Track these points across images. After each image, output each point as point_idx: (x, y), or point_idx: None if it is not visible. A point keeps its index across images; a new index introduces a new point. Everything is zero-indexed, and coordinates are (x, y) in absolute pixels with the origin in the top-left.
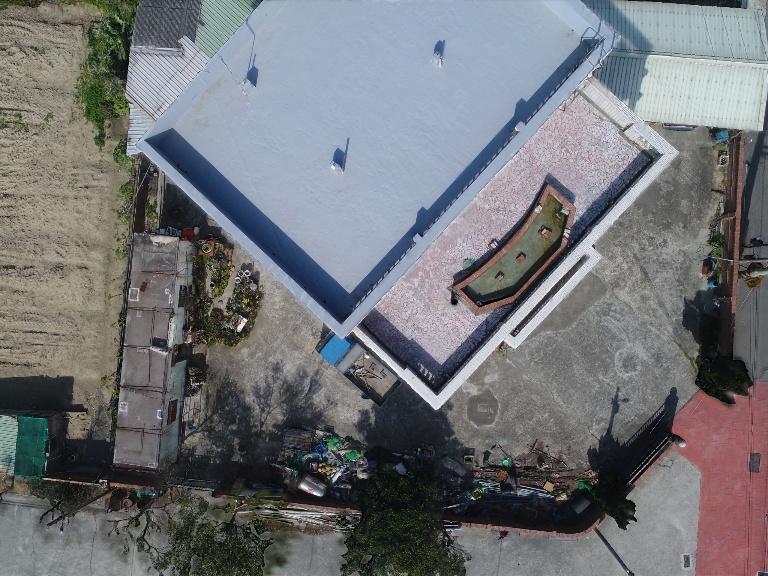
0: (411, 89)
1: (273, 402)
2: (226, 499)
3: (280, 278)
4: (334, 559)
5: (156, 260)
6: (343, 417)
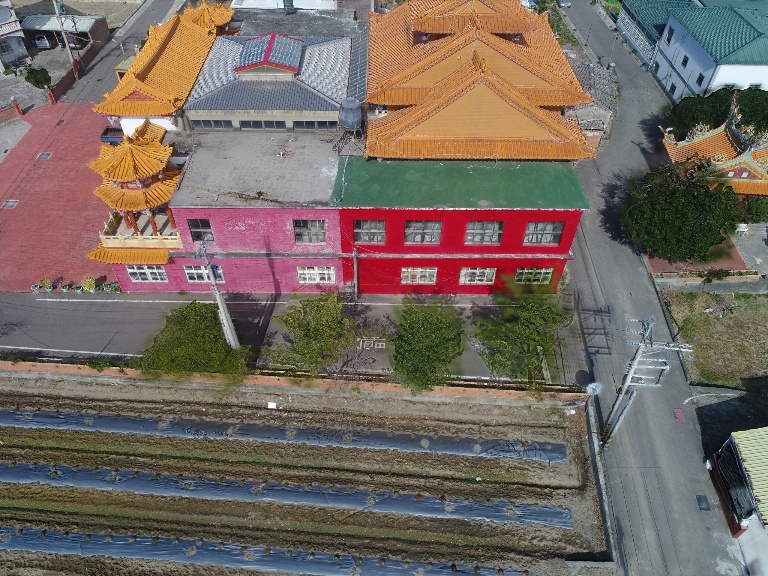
0: None
1: None
2: None
3: None
4: None
5: None
6: None
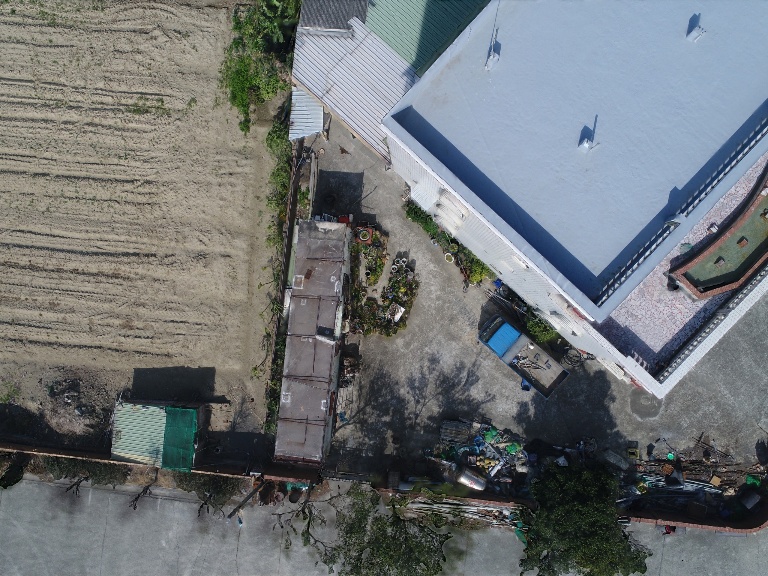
0: (664, 64)
1: (429, 394)
2: None
3: (534, 259)
4: (490, 555)
5: (322, 247)
6: (501, 409)
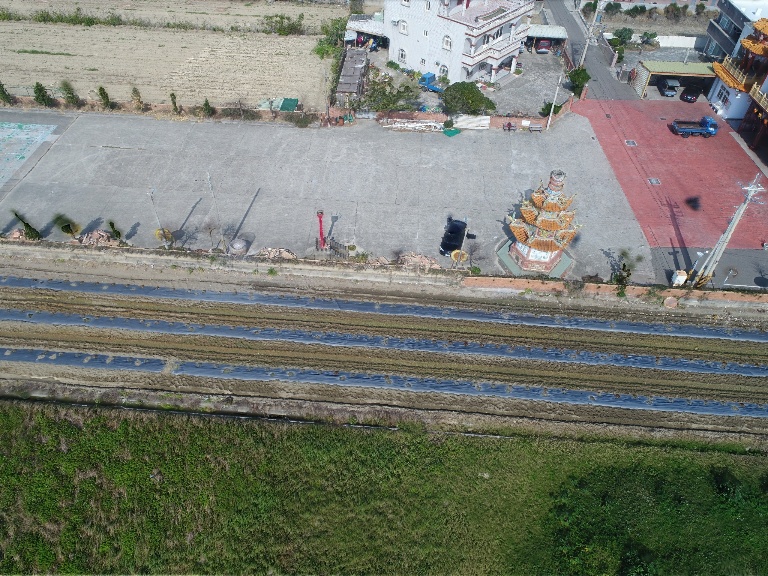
0: None
1: None
2: (379, 124)
3: None
4: None
5: None
6: (431, 104)
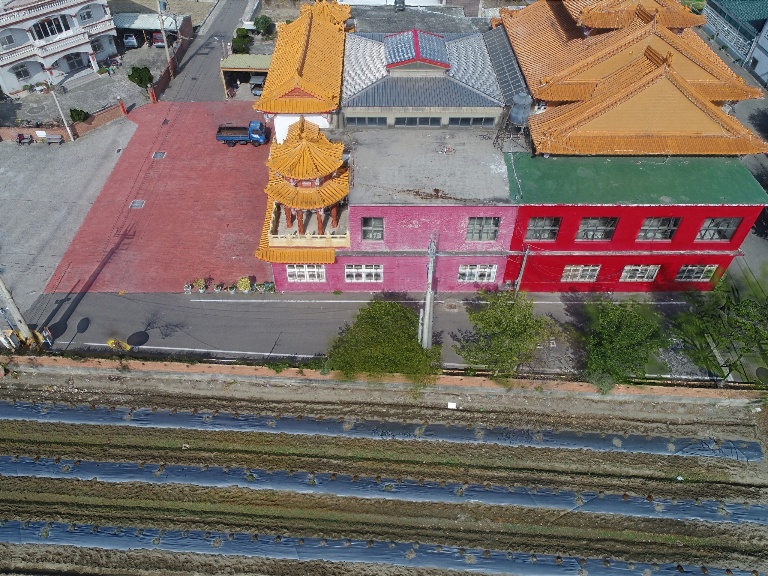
0: None
1: None
2: None
3: None
4: None
5: None
6: None
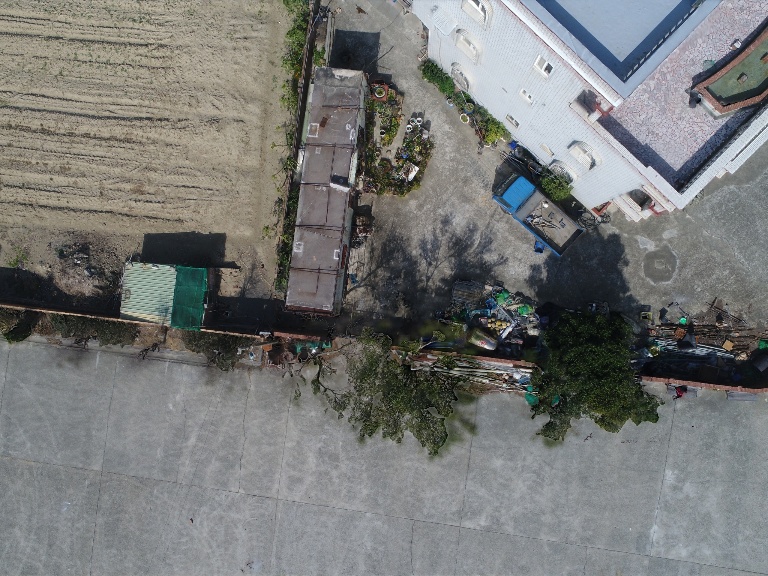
0: None
1: (441, 256)
2: None
3: (560, 34)
4: (499, 419)
5: (338, 94)
6: (514, 272)
